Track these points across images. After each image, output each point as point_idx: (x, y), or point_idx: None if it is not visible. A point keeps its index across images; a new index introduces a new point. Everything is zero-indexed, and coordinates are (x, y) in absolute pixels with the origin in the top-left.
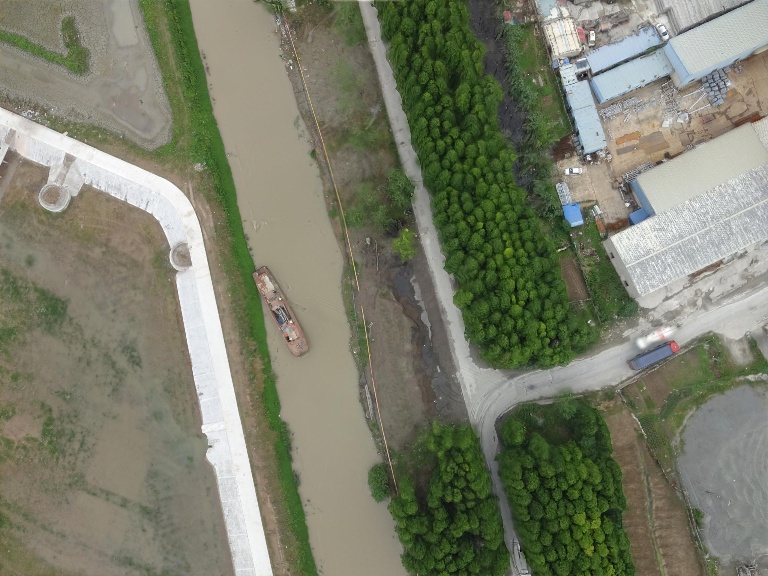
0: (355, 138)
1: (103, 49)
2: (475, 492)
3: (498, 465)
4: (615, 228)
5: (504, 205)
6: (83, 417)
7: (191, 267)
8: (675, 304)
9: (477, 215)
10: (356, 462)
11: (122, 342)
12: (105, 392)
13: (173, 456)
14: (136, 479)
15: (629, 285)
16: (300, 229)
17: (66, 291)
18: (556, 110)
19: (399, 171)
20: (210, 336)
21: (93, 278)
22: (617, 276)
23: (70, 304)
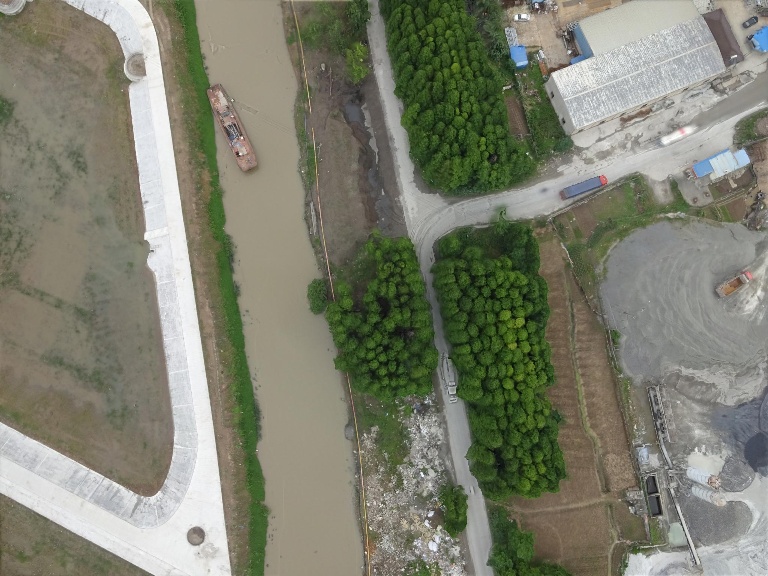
0: None
1: None
2: (409, 284)
3: (433, 276)
4: None
5: (454, 24)
6: (22, 218)
7: (145, 77)
8: (607, 145)
9: (428, 28)
10: (297, 277)
11: (69, 147)
12: (47, 195)
13: (113, 261)
14: (73, 281)
15: (566, 121)
16: (257, 57)
17: (14, 94)
18: None
19: None
20: (159, 144)
21: (43, 83)
22: (556, 116)
23: (17, 107)
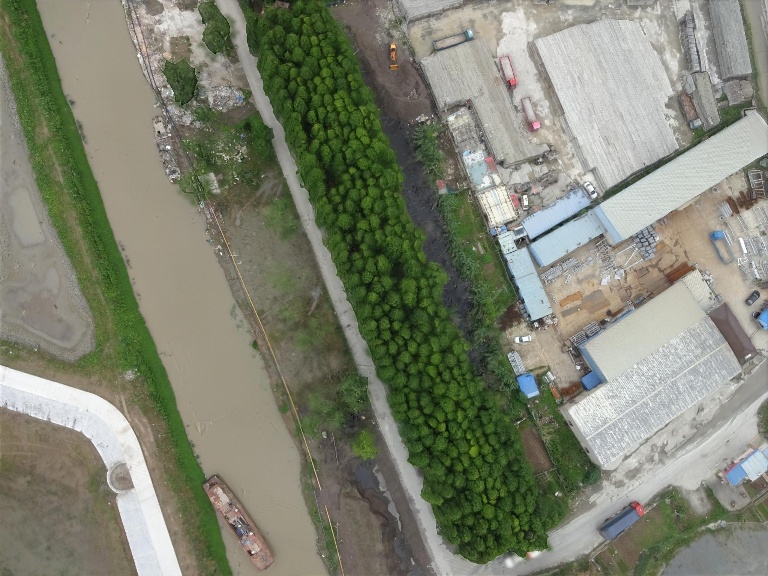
0: (298, 326)
1: (4, 251)
2: None
3: None
4: (570, 393)
5: (464, 402)
6: None
7: (133, 489)
8: (634, 462)
9: (439, 418)
10: None
11: None
12: None
13: None
14: None
15: (590, 453)
16: (249, 424)
17: None
18: (499, 277)
19: (353, 377)
20: (163, 564)
21: (19, 513)
22: (577, 442)
23: None
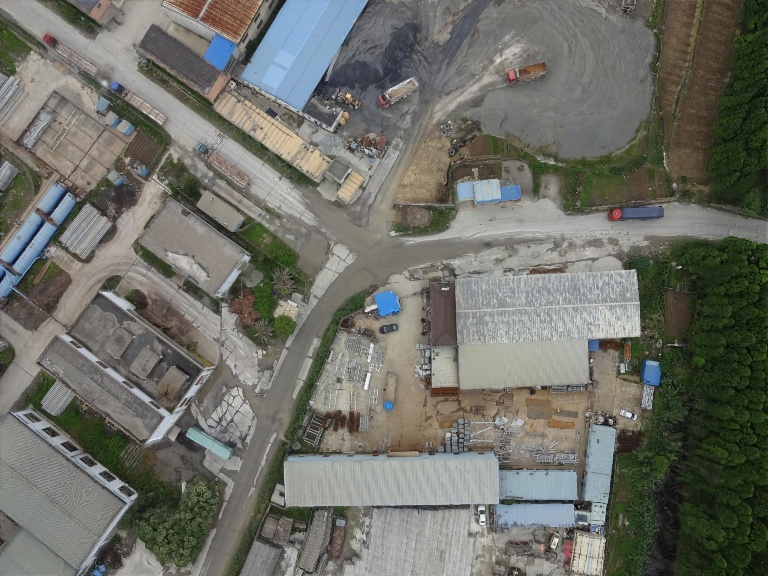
0: None
1: None
2: None
3: None
4: (615, 344)
5: None
6: None
7: None
8: (589, 252)
9: None
10: None
11: None
12: None
13: None
14: None
15: None
16: None
17: None
18: (618, 483)
19: None
20: None
21: None
22: None
23: None
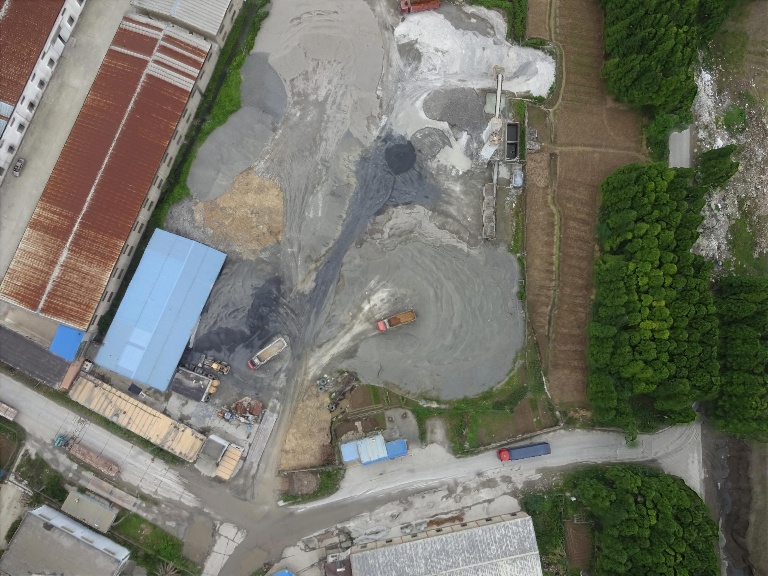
0: None
1: None
2: None
3: None
4: None
5: None
6: None
7: None
8: (483, 494)
9: None
10: None
11: None
12: None
13: None
14: None
15: None
16: None
17: None
18: None
19: None
20: None
21: None
22: None
23: None
